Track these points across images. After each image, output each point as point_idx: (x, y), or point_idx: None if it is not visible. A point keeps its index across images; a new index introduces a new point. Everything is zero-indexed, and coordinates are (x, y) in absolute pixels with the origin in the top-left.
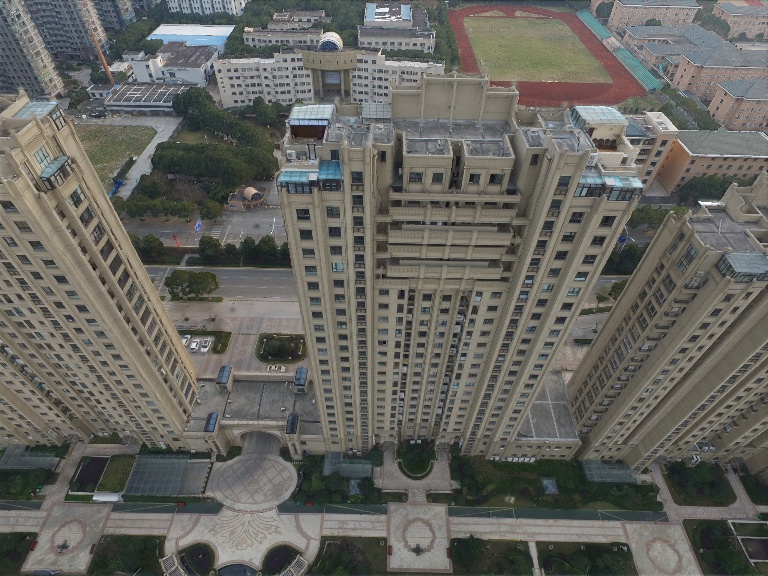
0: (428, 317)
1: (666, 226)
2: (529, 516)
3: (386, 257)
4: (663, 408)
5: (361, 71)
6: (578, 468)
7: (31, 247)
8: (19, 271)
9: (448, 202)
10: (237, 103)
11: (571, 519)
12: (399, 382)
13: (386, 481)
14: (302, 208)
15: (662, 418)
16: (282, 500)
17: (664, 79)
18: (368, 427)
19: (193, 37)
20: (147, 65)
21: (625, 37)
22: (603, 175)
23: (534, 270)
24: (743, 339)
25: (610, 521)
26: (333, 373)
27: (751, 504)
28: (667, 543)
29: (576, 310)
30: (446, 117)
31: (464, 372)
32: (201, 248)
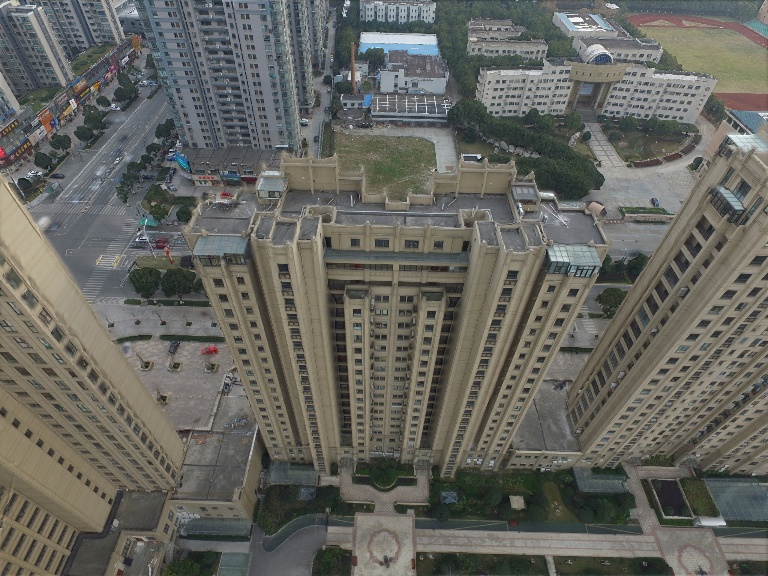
0: None
1: None
2: None
3: None
4: None
5: (624, 83)
6: None
7: None
8: None
9: None
10: None
11: None
12: None
13: None
14: None
15: None
16: None
17: None
18: None
19: (403, 46)
20: (396, 75)
21: None
22: None
23: None
24: None
25: None
26: None
27: None
28: None
29: None
30: None
31: None
32: None
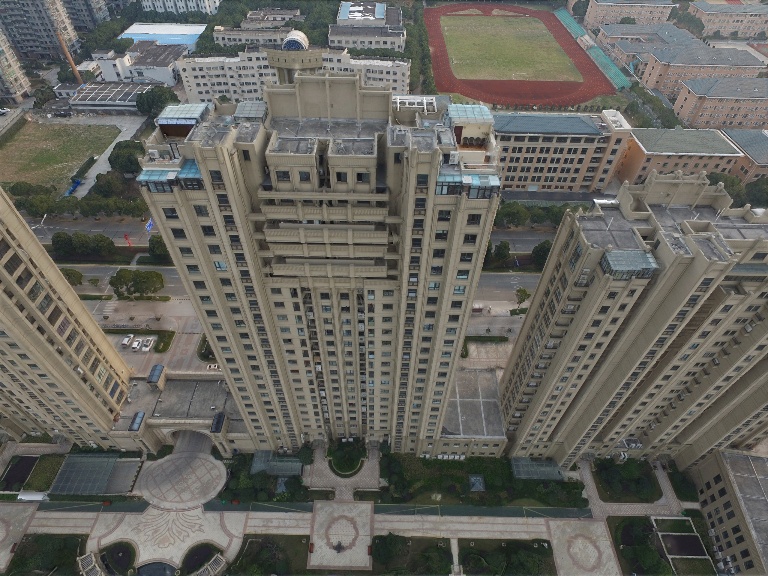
0: (331, 315)
1: (564, 224)
2: (454, 513)
3: (269, 256)
4: (578, 405)
5: None
6: (507, 465)
7: None
8: None
9: (321, 201)
10: None
11: (495, 516)
12: (314, 380)
13: (315, 479)
14: (168, 207)
15: (580, 415)
16: (209, 498)
17: None
18: (293, 425)
19: (165, 36)
20: (114, 64)
21: (599, 35)
22: (463, 173)
23: (416, 268)
24: (639, 336)
25: (534, 518)
26: (242, 372)
27: (676, 500)
28: (589, 539)
29: (466, 308)
30: (326, 116)
31: (376, 370)
32: (150, 247)
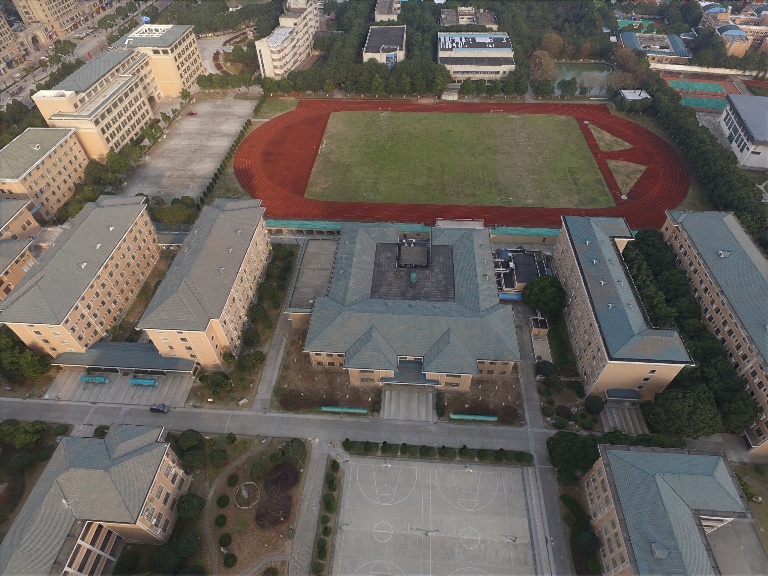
0: None
1: None
2: None
3: None
4: None
5: None
6: None
7: None
8: None
9: None
10: None
11: None
12: None
13: None
14: None
15: None
16: None
17: None
18: None
19: None
20: None
21: None
22: None
23: None
24: None
25: None
26: None
27: None
28: None
29: None
30: None
31: None
32: None
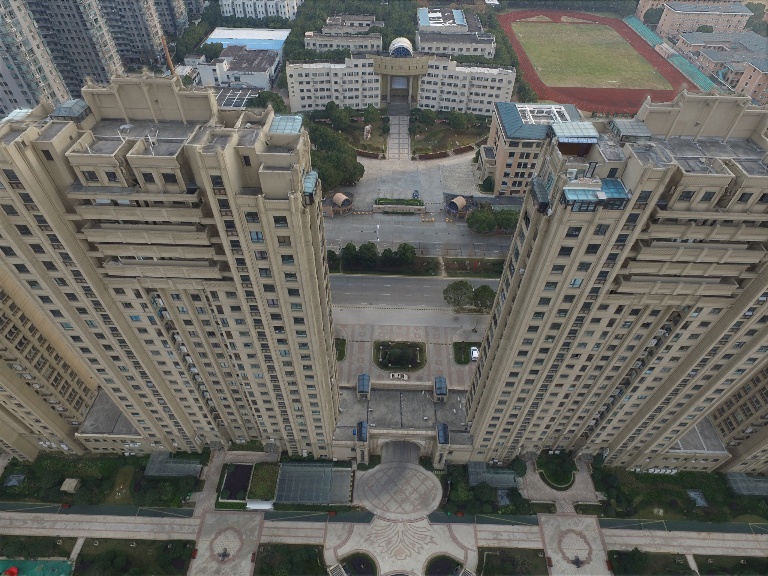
0: (626, 331)
1: None
2: (681, 529)
3: (624, 273)
4: None
5: (431, 77)
6: (721, 480)
7: (281, 261)
8: (254, 284)
9: (706, 220)
10: (304, 108)
11: (724, 532)
12: (571, 394)
13: (531, 492)
14: (575, 226)
15: None
16: (431, 510)
17: (724, 86)
18: (521, 438)
19: (250, 41)
20: (214, 69)
21: (678, 43)
22: None
23: None
24: None
25: (763, 535)
26: (518, 385)
27: None
28: None
29: None
30: (691, 134)
31: (643, 385)
32: None
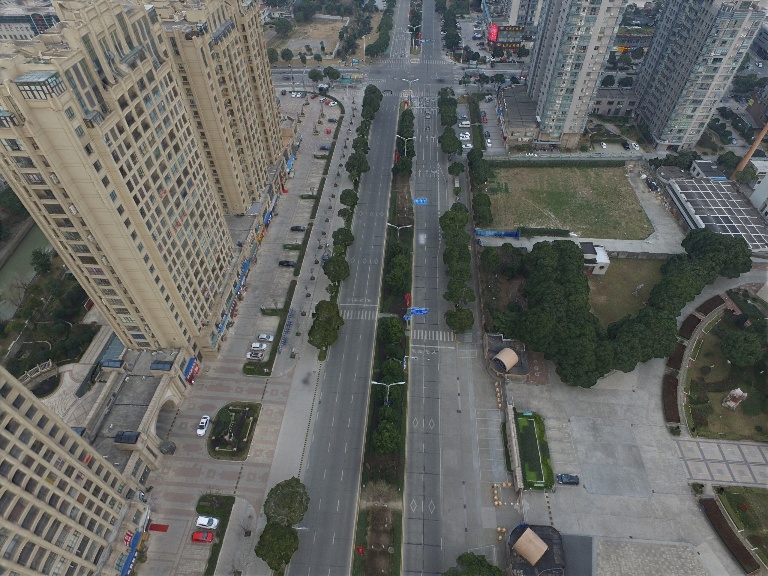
0: None
1: None
2: None
3: None
4: None
5: None
6: None
7: None
8: None
9: None
10: None
11: None
12: None
13: None
14: None
15: None
16: None
17: None
18: None
19: None
20: None
21: None
22: None
23: None
24: None
25: None
26: None
27: None
28: None
29: None
30: None
31: None
32: None
